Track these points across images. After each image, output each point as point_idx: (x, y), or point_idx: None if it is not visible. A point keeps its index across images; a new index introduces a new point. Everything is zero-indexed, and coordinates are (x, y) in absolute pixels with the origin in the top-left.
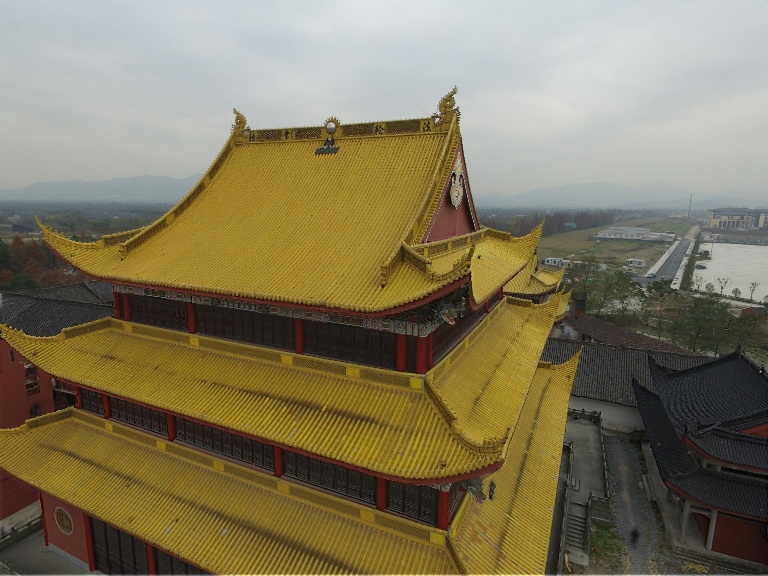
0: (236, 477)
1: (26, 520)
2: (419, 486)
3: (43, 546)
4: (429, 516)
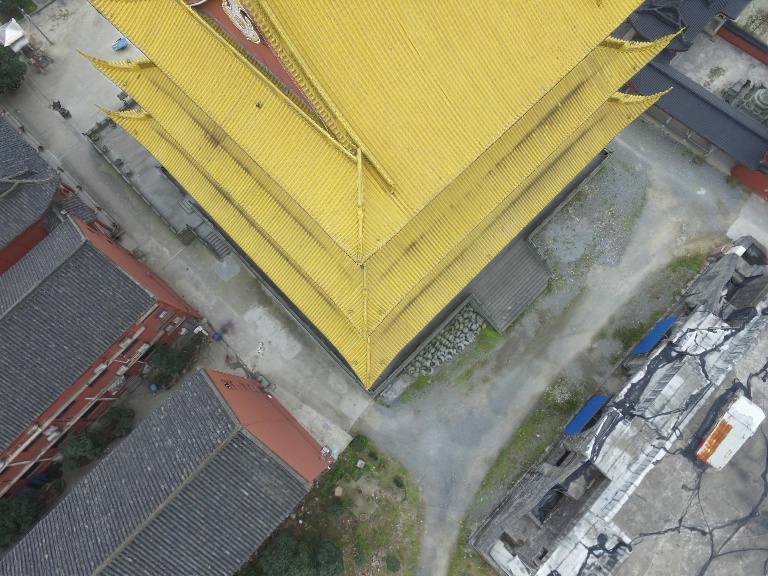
0: None
1: (301, 396)
2: None
3: None
4: None
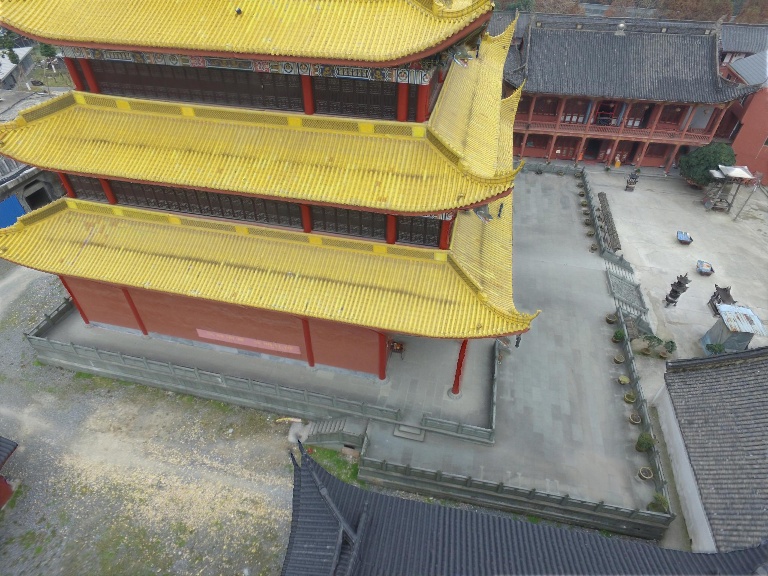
0: None
1: None
2: None
3: None
4: None
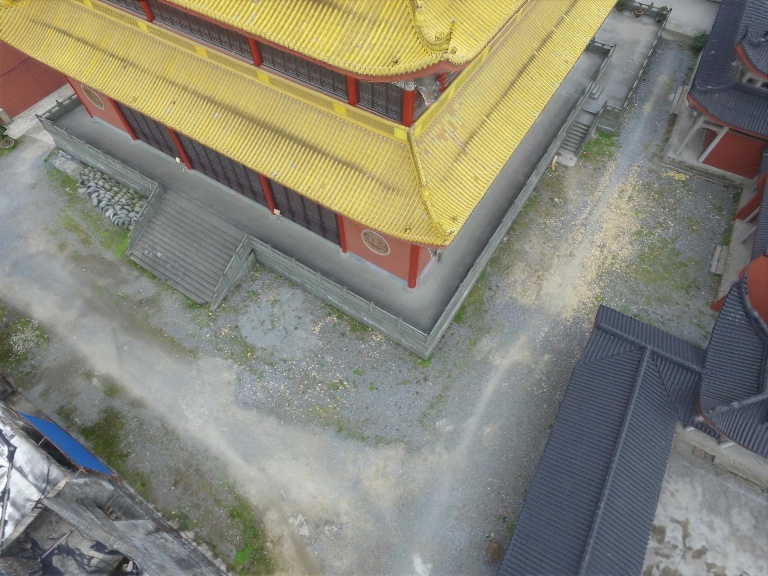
0: (220, 64)
1: None
2: (384, 83)
3: (89, 118)
4: (395, 113)
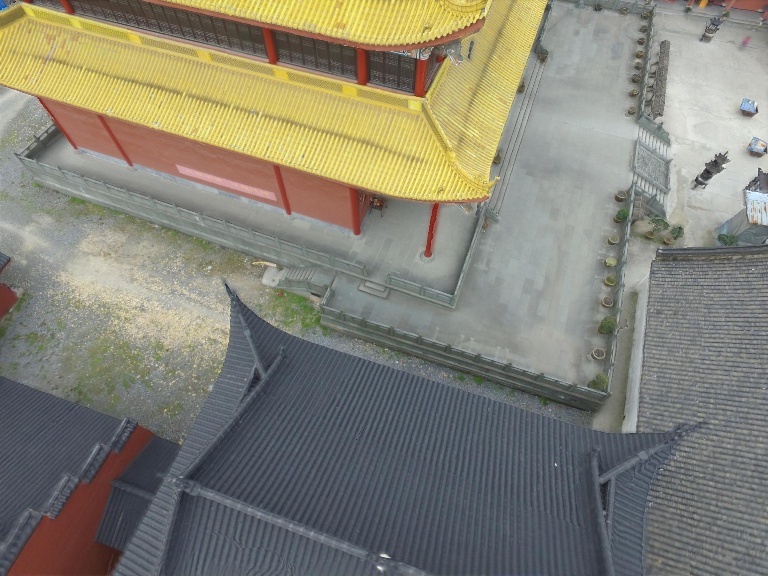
0: None
1: None
2: None
3: None
4: None
